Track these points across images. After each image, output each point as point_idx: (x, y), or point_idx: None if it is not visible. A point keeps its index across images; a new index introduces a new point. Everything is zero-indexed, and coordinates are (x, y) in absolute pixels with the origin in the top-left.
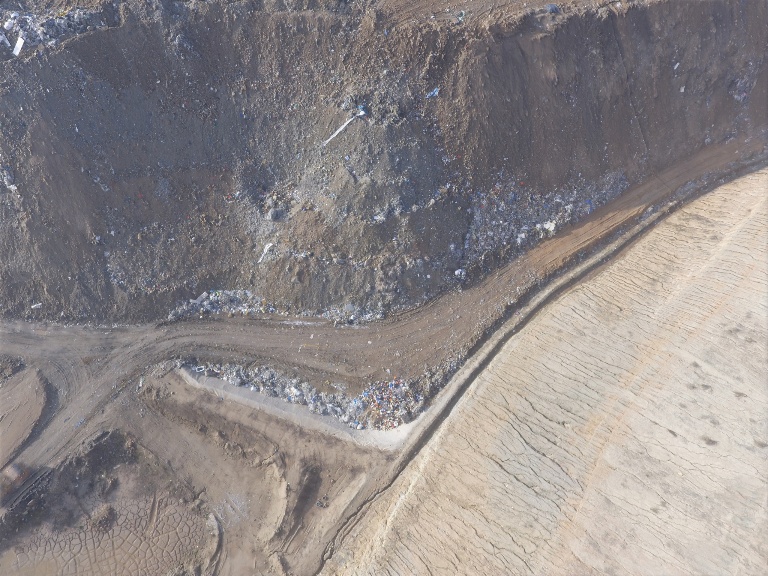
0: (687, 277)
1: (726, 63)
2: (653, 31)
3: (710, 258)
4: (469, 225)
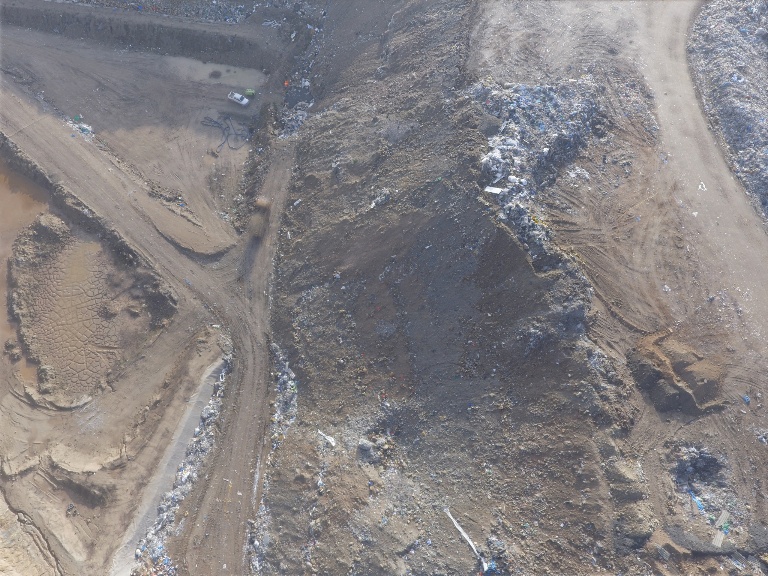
0: None
1: None
2: None
3: None
4: None
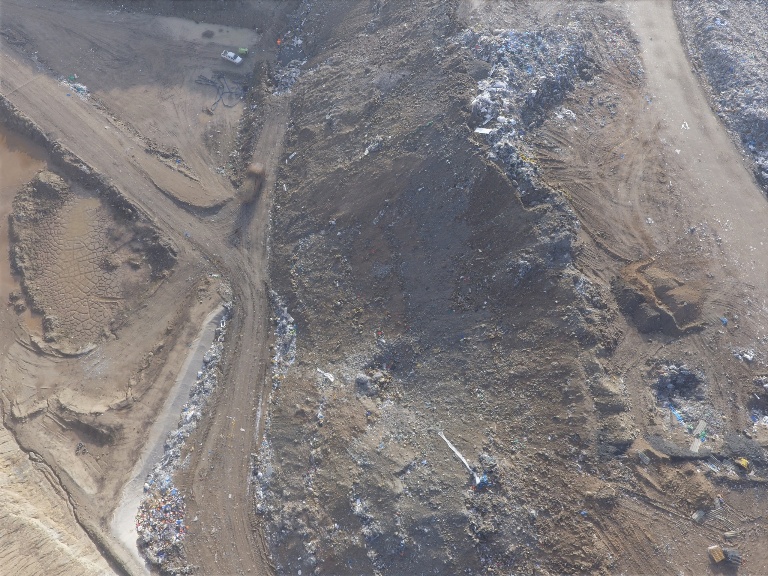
0: None
1: None
2: None
3: None
4: None
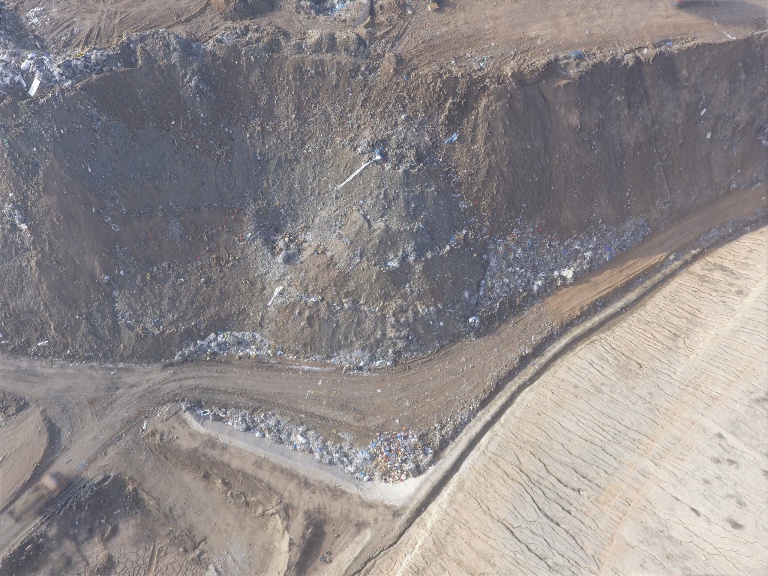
0: (711, 335)
1: (755, 109)
2: (680, 77)
3: (735, 315)
4: (484, 272)
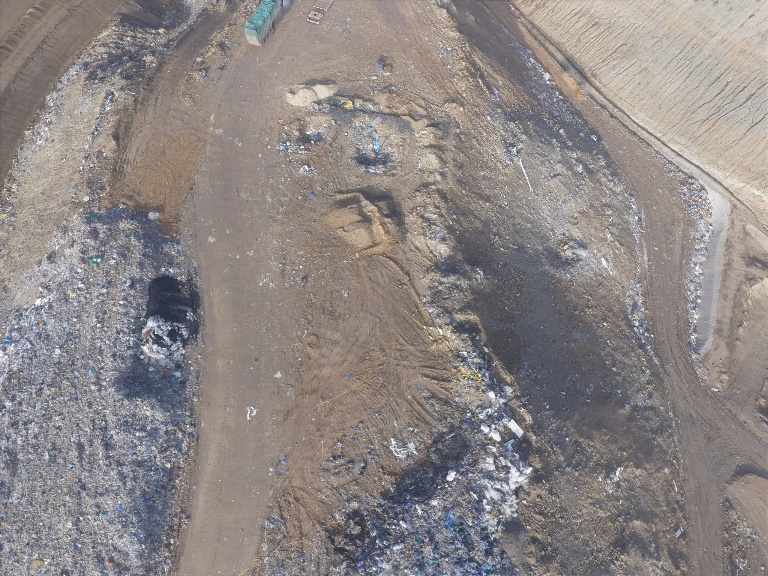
0: (601, 3)
1: None
2: None
3: None
4: None
